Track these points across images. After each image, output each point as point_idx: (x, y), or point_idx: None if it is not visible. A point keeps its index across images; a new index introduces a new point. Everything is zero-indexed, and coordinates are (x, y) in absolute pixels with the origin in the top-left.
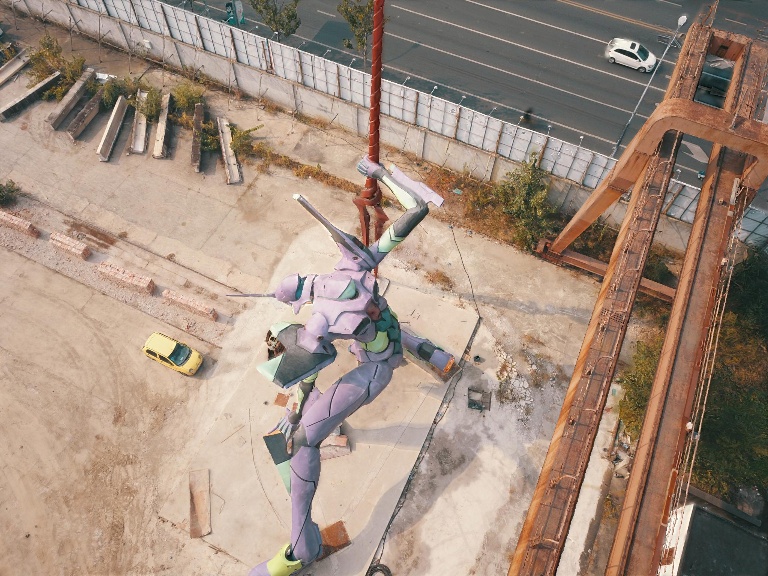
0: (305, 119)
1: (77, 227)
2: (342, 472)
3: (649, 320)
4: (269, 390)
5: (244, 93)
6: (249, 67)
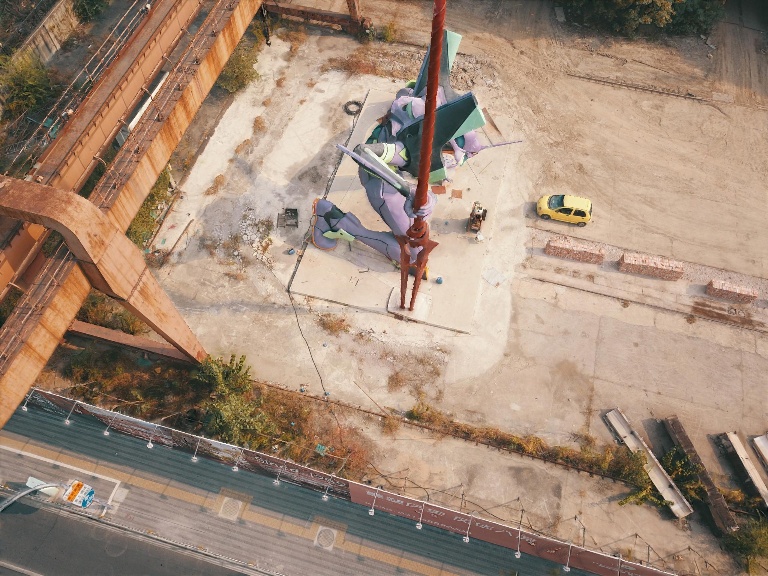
0: None
1: (745, 321)
2: None
3: None
4: (470, 199)
5: None
6: None
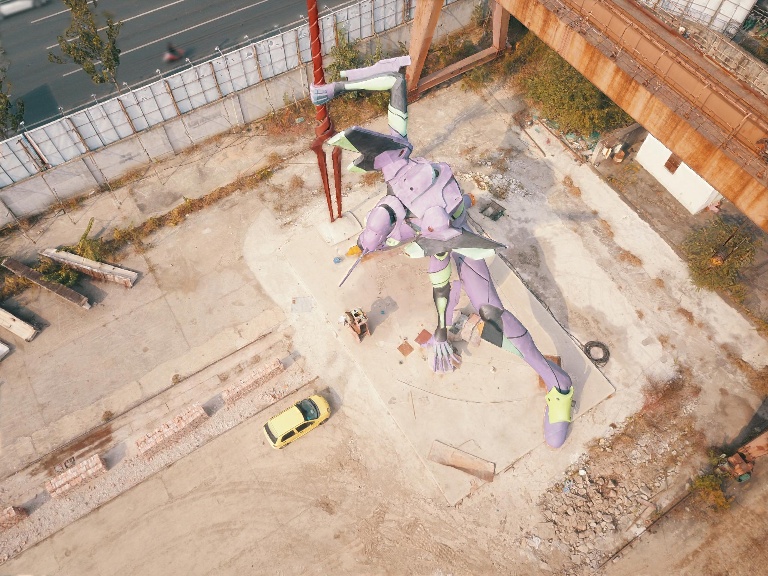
0: (114, 185)
1: (52, 463)
2: None
3: (498, 79)
4: (389, 355)
5: (28, 218)
6: (18, 183)
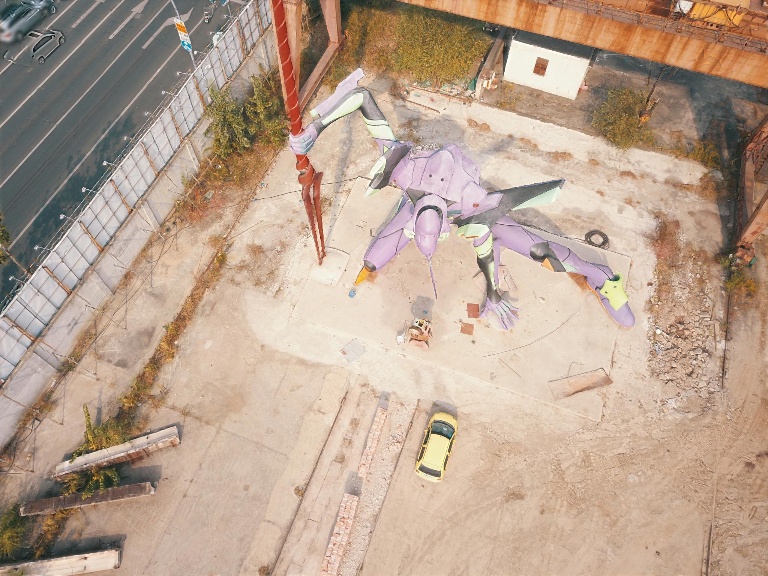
0: None
1: None
2: (523, 271)
3: (352, 69)
4: (459, 342)
5: (3, 452)
6: None
